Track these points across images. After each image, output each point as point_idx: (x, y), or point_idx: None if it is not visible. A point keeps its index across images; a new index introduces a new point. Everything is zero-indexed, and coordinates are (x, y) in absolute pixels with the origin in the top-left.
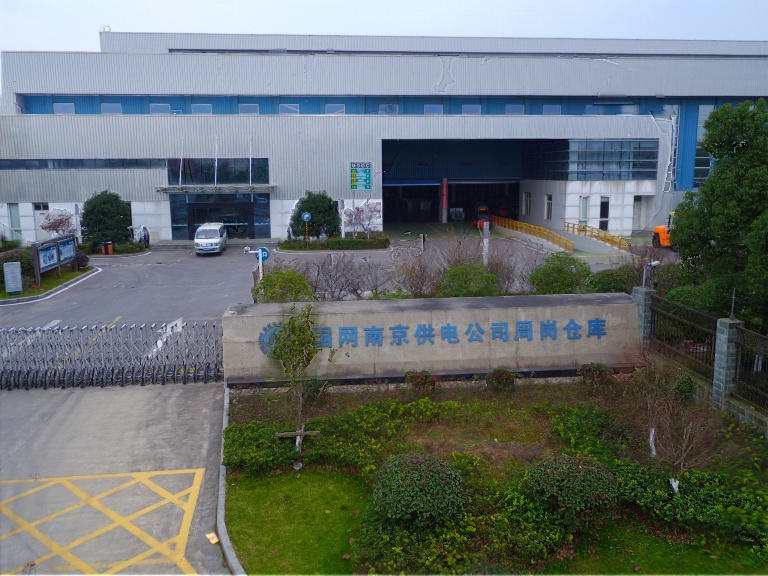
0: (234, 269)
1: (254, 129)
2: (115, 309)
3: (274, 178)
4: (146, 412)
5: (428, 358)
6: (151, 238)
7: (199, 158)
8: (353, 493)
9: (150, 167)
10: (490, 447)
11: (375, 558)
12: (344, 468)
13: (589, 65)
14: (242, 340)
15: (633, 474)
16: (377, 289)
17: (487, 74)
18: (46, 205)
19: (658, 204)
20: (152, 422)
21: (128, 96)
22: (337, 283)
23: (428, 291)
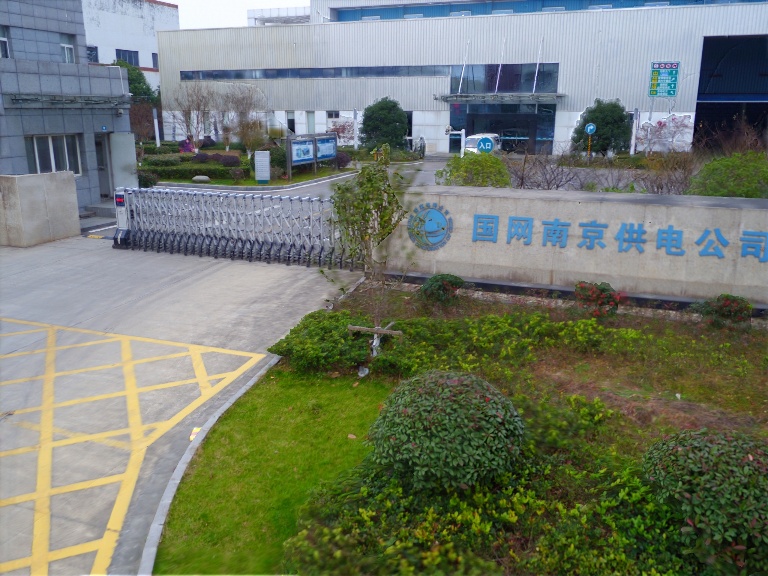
0: None
1: (546, 29)
2: None
3: (563, 86)
4: (266, 289)
5: (631, 272)
6: (429, 150)
7: (484, 64)
8: None
9: (434, 74)
10: (659, 403)
11: (324, 517)
12: None
13: None
14: None
15: None
16: None
17: None
18: (338, 113)
19: None
20: (261, 299)
21: (430, 6)
22: None
23: None
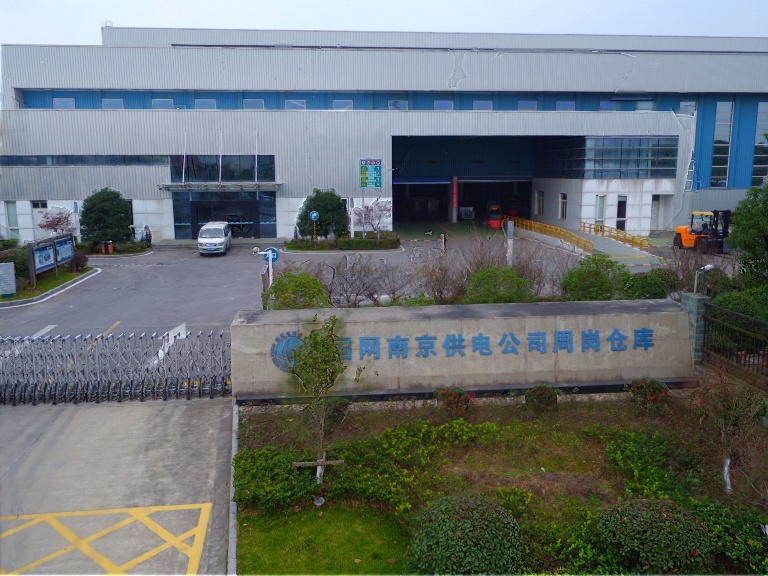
0: (240, 270)
1: (260, 125)
2: (114, 313)
3: (280, 175)
4: (145, 433)
5: (458, 372)
6: (153, 237)
7: (203, 155)
8: (385, 536)
9: (152, 164)
10: (538, 478)
11: None
12: (373, 504)
13: (604, 60)
14: (252, 351)
15: (716, 517)
16: (395, 293)
17: (499, 69)
18: (45, 203)
19: (677, 203)
20: (152, 445)
21: (130, 91)
22: (353, 287)
23: (449, 295)
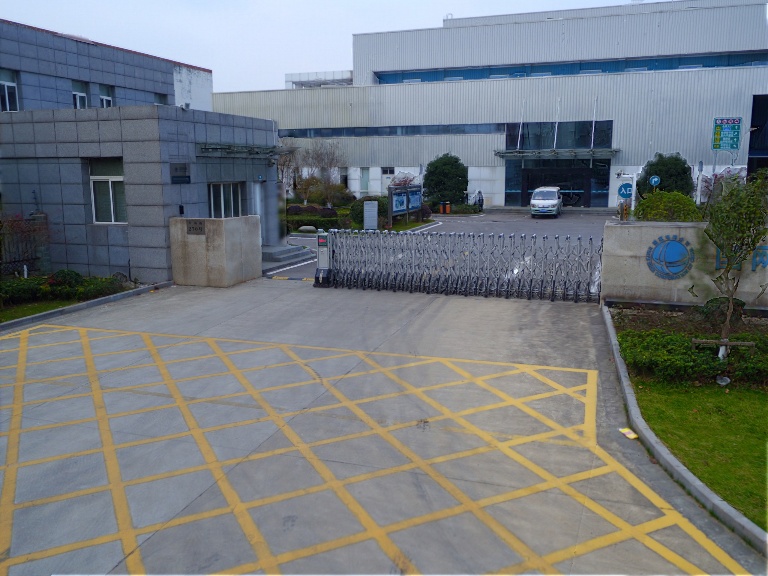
0: (575, 227)
1: (600, 89)
2: None
3: (618, 142)
4: (516, 318)
5: None
6: (484, 203)
7: (539, 122)
8: None
9: (489, 132)
10: None
11: None
12: None
13: None
14: (626, 254)
15: None
16: None
17: None
18: (392, 170)
19: None
20: (525, 326)
21: (470, 69)
22: None
23: None
